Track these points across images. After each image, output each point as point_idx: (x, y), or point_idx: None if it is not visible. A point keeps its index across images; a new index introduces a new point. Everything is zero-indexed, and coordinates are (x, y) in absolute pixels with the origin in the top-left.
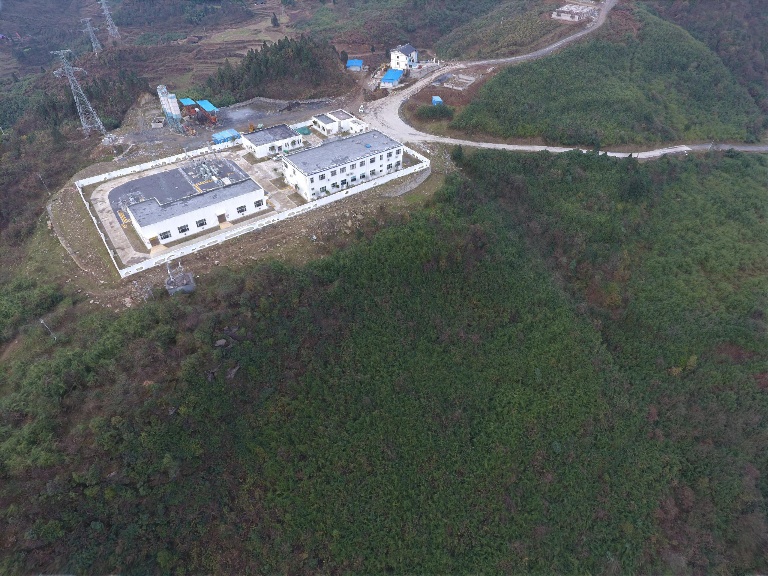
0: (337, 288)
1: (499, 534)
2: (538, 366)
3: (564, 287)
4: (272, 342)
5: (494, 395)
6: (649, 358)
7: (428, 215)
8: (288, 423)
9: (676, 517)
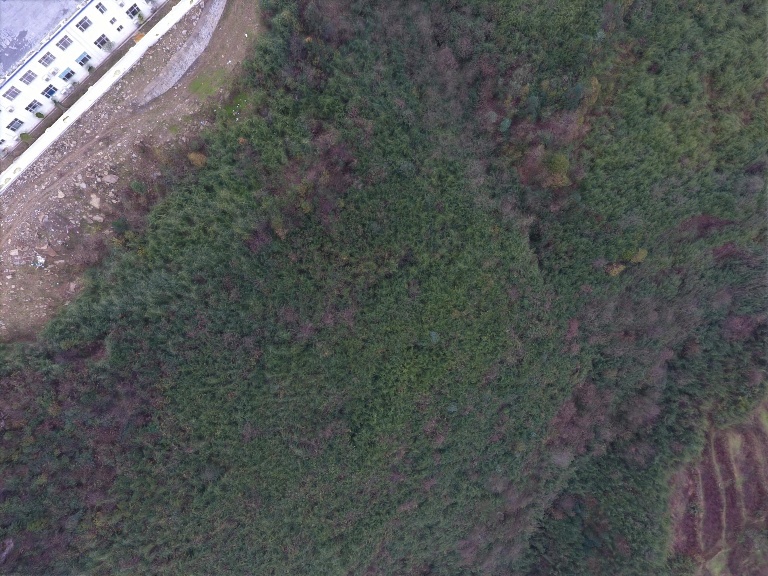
0: (112, 355)
1: (388, 501)
2: (434, 329)
3: (487, 169)
4: (45, 479)
5: (379, 373)
6: (587, 258)
7: (235, 140)
8: (118, 537)
9: (572, 416)
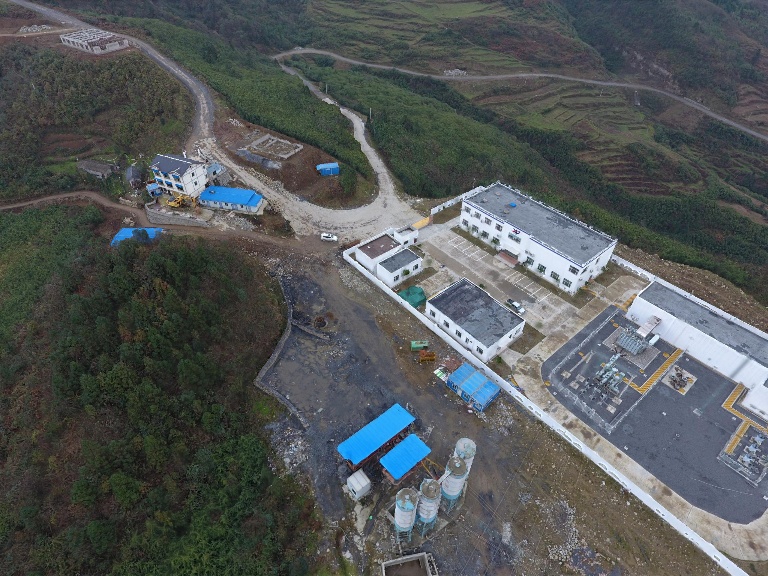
0: None
1: None
2: None
3: None
4: None
5: None
6: None
7: None
8: None
9: None
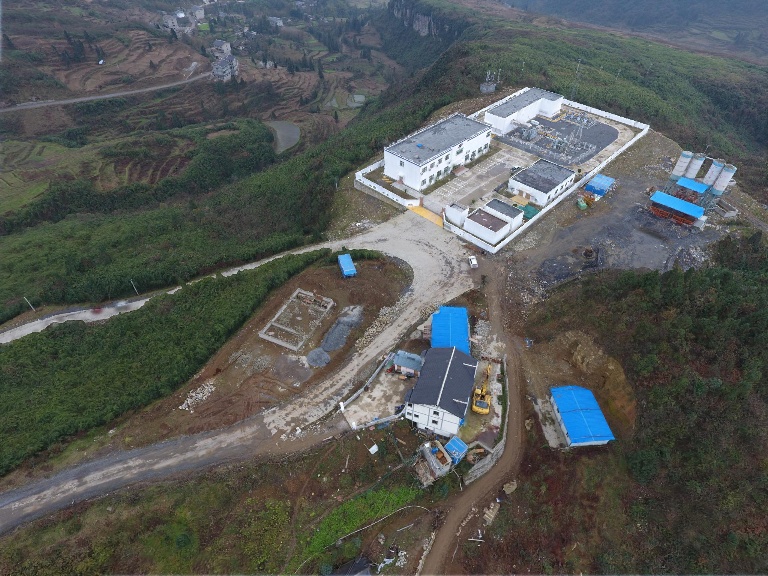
0: None
1: None
2: None
3: None
4: None
5: None
6: None
7: None
8: None
9: None
